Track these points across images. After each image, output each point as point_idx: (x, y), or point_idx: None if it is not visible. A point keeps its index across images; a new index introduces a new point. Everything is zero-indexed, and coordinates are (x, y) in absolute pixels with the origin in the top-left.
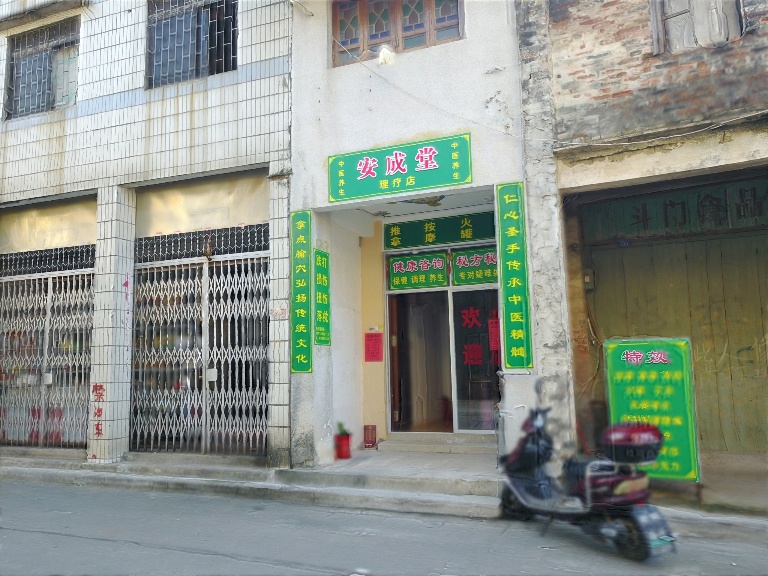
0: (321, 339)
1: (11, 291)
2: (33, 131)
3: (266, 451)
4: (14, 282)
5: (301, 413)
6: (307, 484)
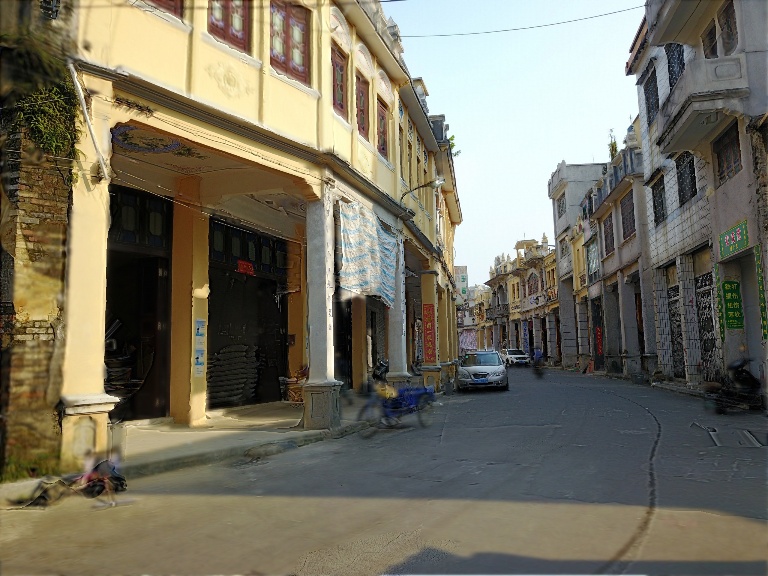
0: (735, 326)
1: None
2: None
3: None
4: None
5: None
6: None
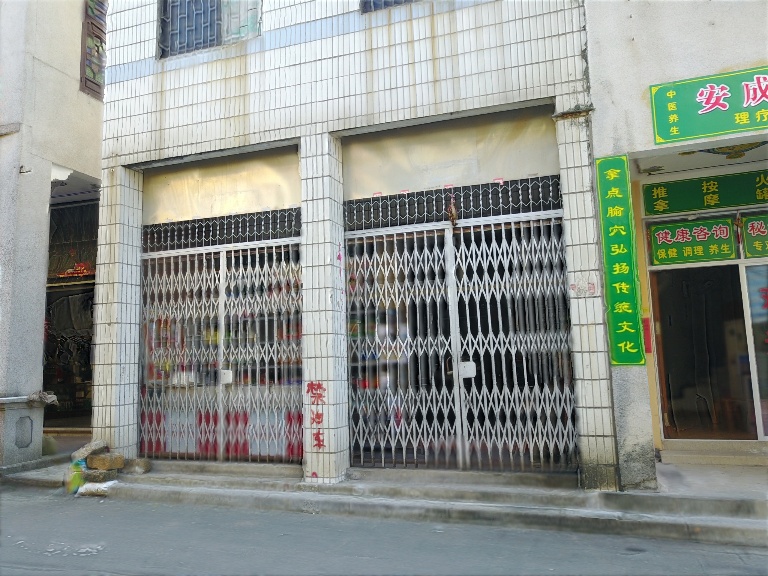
0: None
1: (167, 269)
2: (201, 70)
3: (555, 467)
4: (171, 258)
5: (632, 418)
6: (655, 512)
